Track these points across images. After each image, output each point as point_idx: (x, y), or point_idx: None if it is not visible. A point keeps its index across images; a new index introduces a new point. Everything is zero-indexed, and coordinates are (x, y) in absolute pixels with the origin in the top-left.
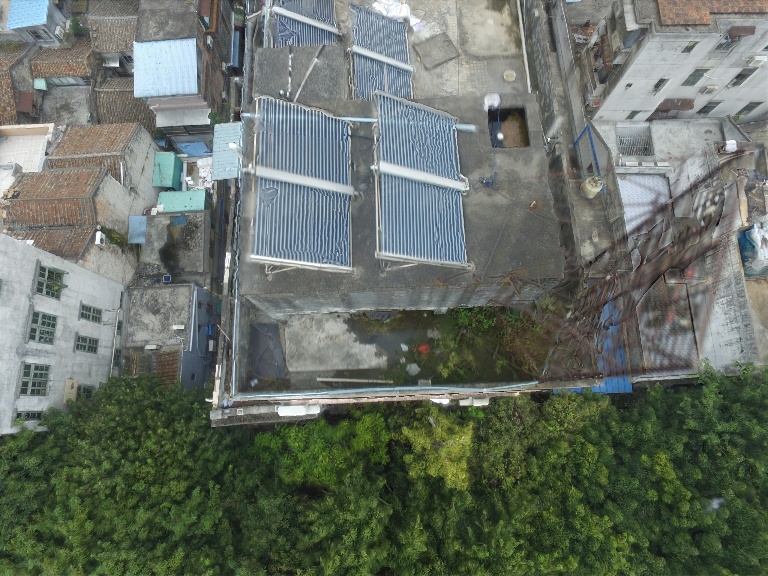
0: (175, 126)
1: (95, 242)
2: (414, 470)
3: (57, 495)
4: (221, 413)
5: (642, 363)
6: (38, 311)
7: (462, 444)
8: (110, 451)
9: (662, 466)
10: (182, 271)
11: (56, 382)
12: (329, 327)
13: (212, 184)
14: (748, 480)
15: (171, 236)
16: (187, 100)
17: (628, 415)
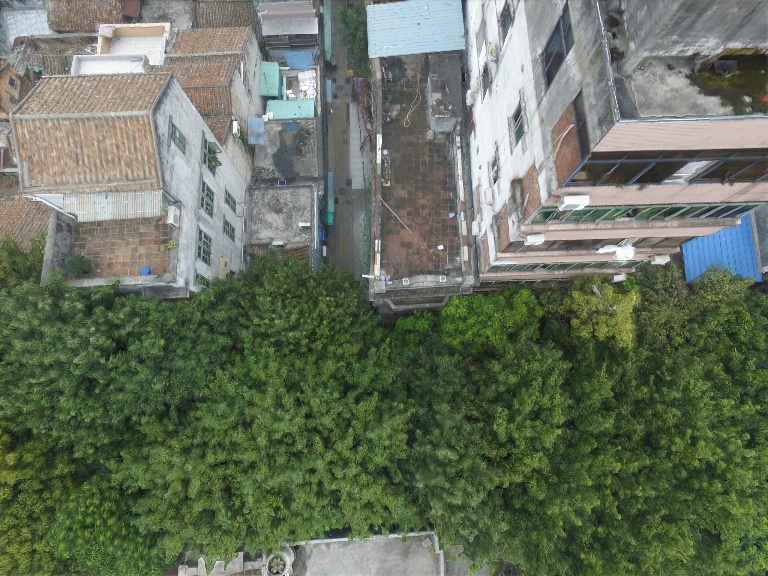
0: (281, 35)
1: (233, 131)
2: (585, 331)
3: None
4: (384, 284)
5: None
6: (204, 181)
7: None
8: (290, 310)
9: None
10: (297, 176)
11: (215, 257)
12: (673, 81)
13: (315, 97)
14: None
15: (284, 142)
16: (297, 6)
17: (767, 297)
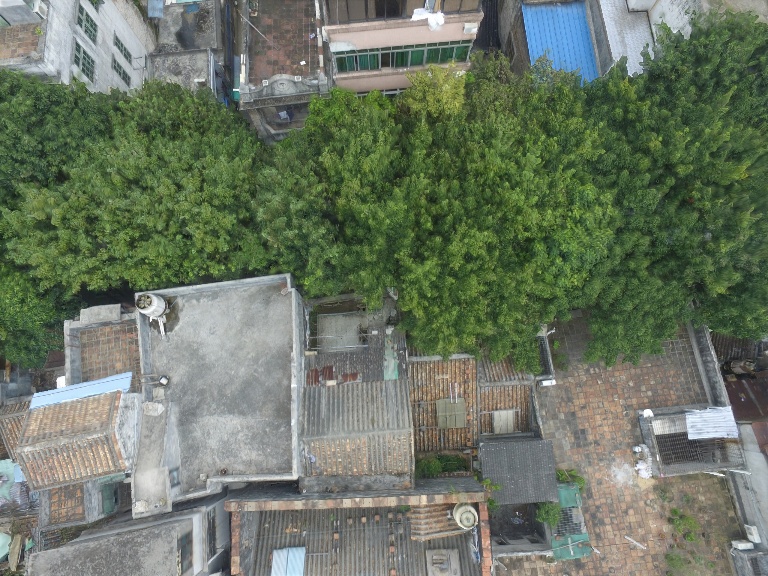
0: None
1: None
2: (418, 105)
3: (114, 131)
4: (248, 89)
5: (609, 53)
6: (83, 7)
7: (457, 94)
8: None
9: (626, 87)
10: (198, 48)
11: (100, 80)
12: None
13: None
14: (698, 101)
15: (185, 21)
16: None
17: None
